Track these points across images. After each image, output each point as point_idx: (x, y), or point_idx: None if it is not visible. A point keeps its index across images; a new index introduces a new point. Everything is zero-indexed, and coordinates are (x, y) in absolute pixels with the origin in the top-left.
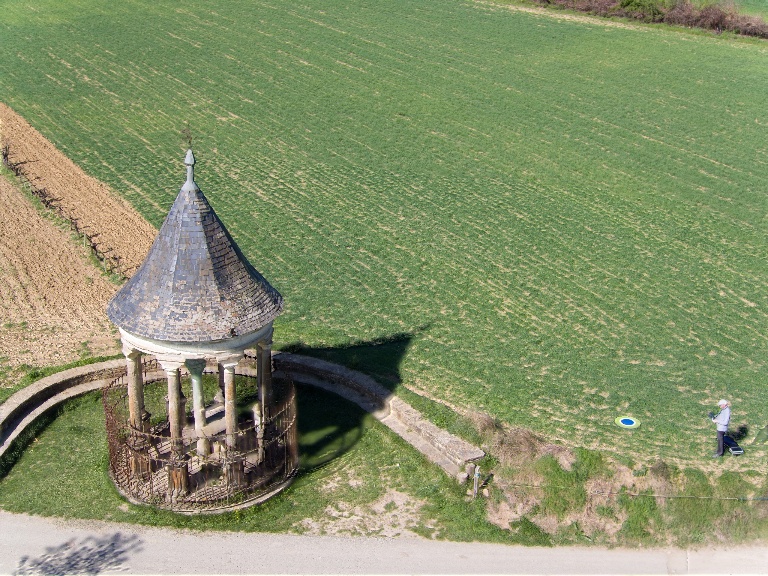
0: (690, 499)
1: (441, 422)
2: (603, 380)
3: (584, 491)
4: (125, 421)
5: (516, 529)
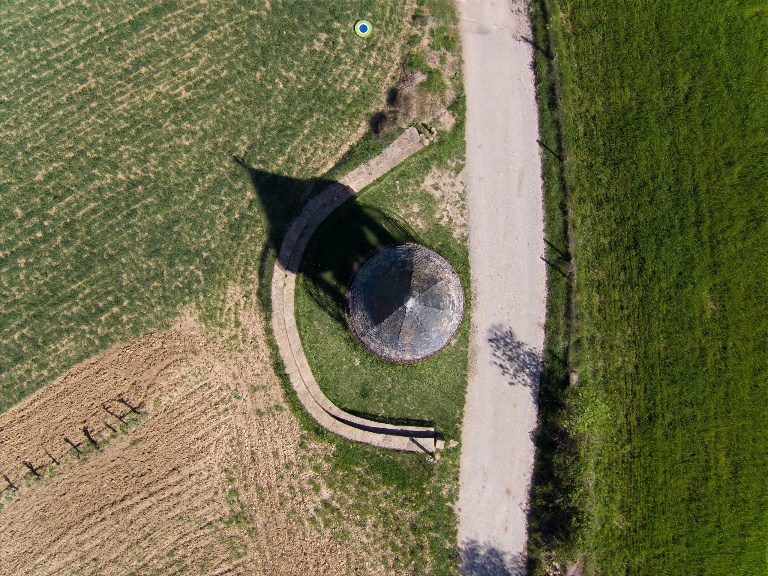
0: (436, 8)
1: (378, 152)
2: (302, 34)
3: (436, 70)
4: (352, 364)
5: (455, 115)
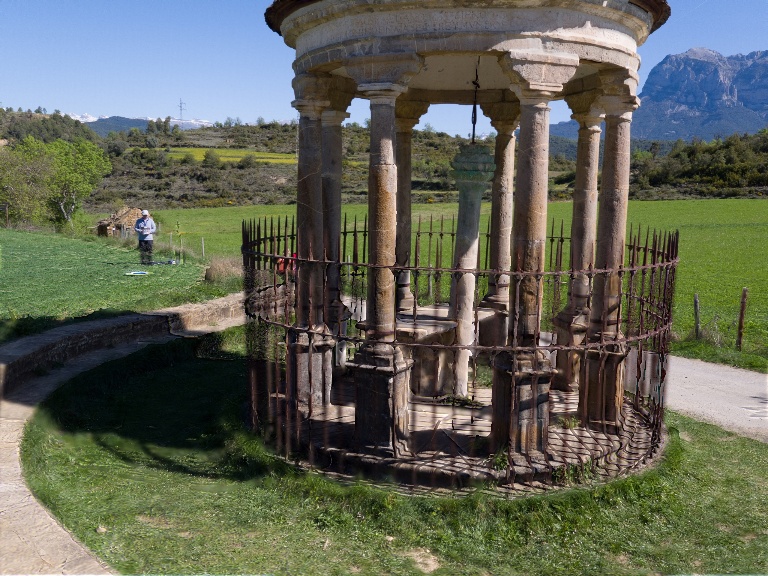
0: None
1: None
2: None
3: None
4: (402, 574)
5: None
